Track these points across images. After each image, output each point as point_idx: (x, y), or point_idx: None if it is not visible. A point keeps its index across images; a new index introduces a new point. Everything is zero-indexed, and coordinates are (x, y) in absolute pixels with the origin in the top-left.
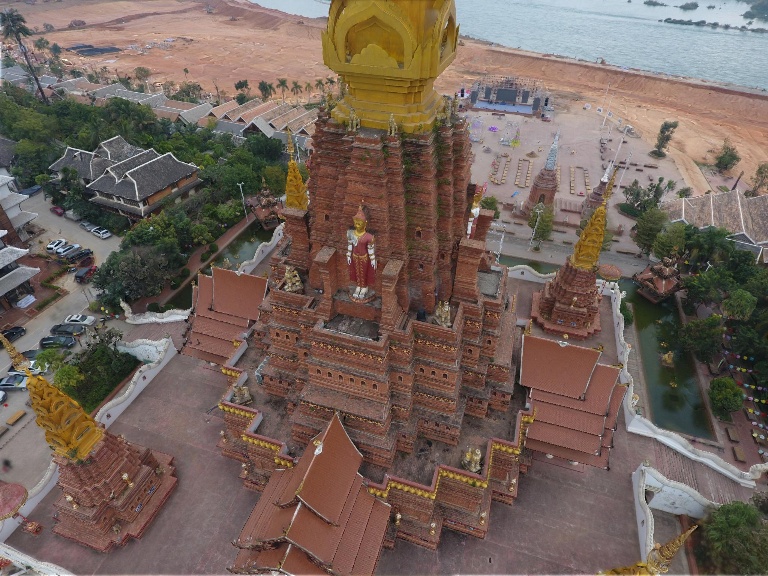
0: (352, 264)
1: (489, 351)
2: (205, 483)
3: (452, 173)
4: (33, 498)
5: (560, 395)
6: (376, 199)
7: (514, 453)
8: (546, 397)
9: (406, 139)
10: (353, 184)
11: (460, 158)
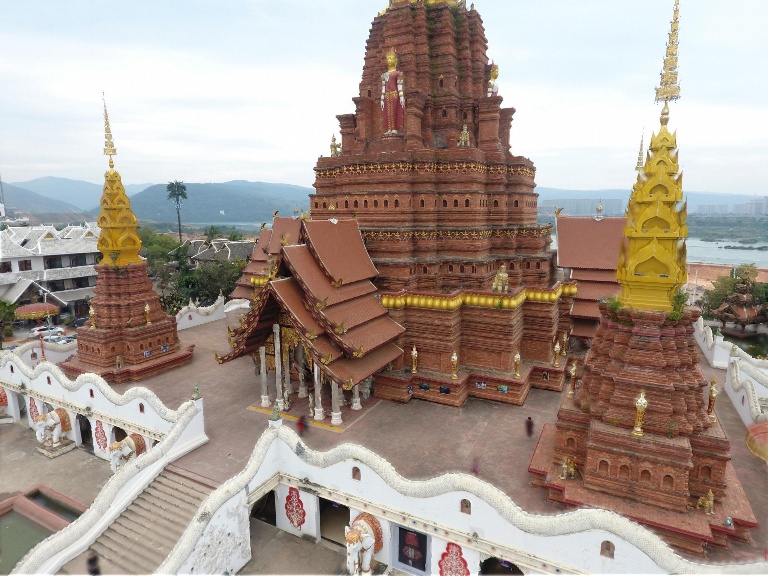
0: (385, 108)
1: (518, 216)
2: (217, 364)
3: (470, 48)
4: (56, 353)
5: (604, 271)
6: (406, 45)
7: (551, 300)
8: (589, 276)
9: (430, 9)
10: (389, 40)
11: (475, 33)
